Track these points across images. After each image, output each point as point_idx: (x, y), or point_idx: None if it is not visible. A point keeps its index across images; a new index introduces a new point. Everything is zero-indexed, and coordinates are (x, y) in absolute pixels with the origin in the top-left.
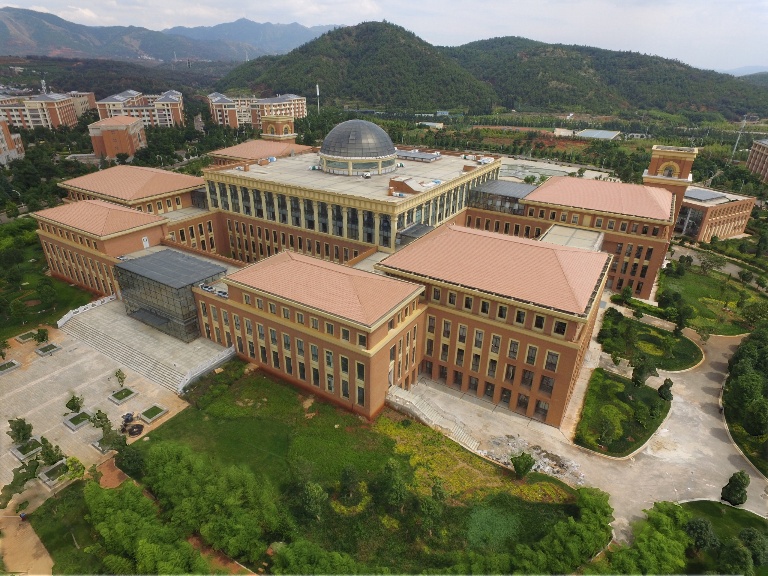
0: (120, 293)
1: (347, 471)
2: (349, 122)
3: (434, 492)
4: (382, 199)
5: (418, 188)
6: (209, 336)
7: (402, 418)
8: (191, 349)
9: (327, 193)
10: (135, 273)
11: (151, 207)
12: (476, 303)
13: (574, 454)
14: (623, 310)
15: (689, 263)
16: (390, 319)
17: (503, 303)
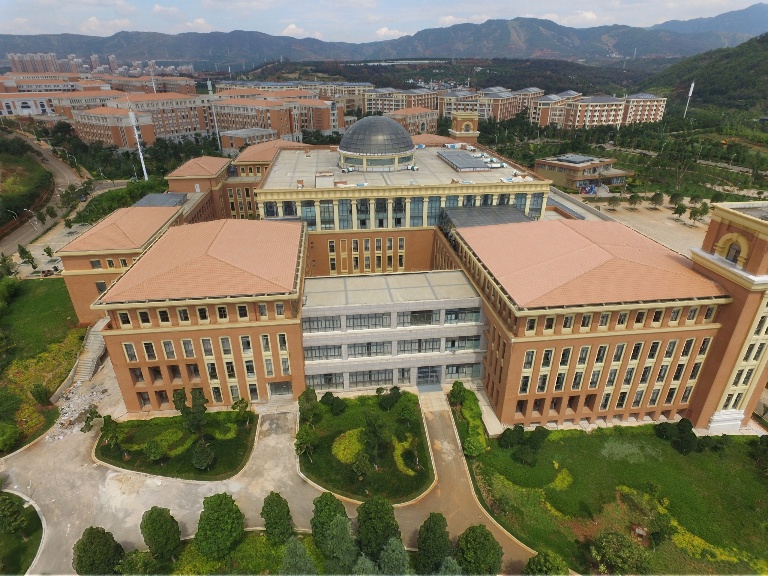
0: None
1: None
2: None
3: None
4: None
5: (324, 185)
6: None
7: None
8: None
9: None
10: None
11: (252, 170)
12: None
13: None
14: (439, 408)
15: (761, 449)
16: (93, 259)
17: None
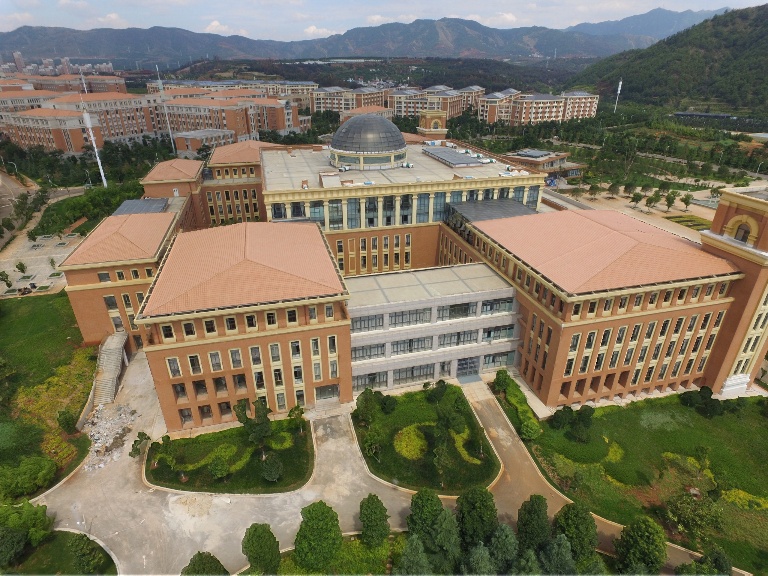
0: None
1: None
2: None
3: None
4: (286, 188)
5: (331, 185)
6: None
7: None
8: None
9: None
10: None
11: (228, 172)
12: None
13: None
14: (484, 398)
15: None
16: (101, 271)
17: None
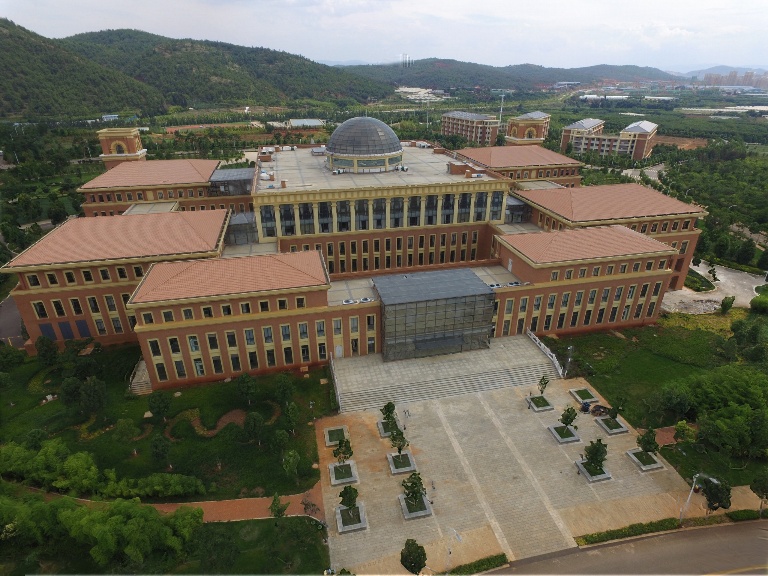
0: (340, 349)
1: (745, 334)
2: (362, 120)
3: (763, 324)
4: None
5: None
6: (490, 335)
7: (658, 316)
8: (501, 350)
9: (440, 185)
10: (427, 300)
11: None
12: (640, 227)
13: (706, 296)
14: None
15: None
16: None
17: (660, 220)
